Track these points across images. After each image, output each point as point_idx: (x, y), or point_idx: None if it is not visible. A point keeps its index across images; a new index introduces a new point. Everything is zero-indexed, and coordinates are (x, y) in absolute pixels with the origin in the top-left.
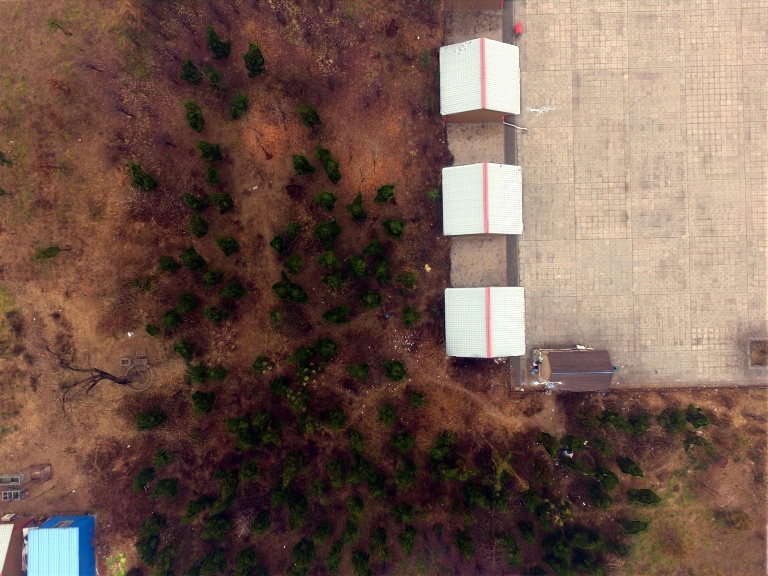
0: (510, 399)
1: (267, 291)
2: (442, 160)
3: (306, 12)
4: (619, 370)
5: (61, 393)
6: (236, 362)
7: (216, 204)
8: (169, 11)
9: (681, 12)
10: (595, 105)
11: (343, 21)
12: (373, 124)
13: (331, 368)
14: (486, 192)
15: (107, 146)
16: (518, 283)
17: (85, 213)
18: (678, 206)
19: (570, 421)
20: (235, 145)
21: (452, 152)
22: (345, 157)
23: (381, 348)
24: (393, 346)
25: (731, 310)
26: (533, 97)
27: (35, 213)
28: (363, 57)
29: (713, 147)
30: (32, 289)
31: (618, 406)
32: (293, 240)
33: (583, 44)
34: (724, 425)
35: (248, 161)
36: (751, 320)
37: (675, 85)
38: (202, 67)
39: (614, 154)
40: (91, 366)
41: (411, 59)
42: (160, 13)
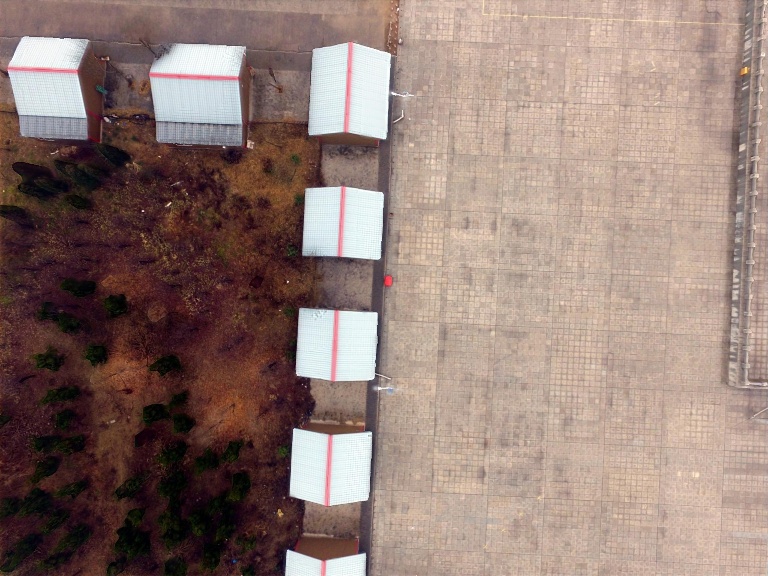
0: None
1: (116, 527)
2: (303, 405)
3: (177, 249)
4: None
5: None
6: None
7: None
8: (40, 240)
9: (552, 273)
10: (460, 359)
11: (213, 261)
12: (236, 365)
13: None
14: (329, 465)
15: None
16: (371, 532)
17: None
18: (536, 466)
19: None
20: None
21: (314, 397)
22: (205, 397)
23: None
24: None
25: (581, 575)
26: (399, 346)
27: None
28: (231, 298)
29: (574, 410)
30: None
31: None
32: (147, 477)
33: (452, 298)
34: None
35: (108, 394)
36: None
37: (541, 345)
38: None
39: (476, 409)
40: None
41: (279, 303)
42: (31, 241)
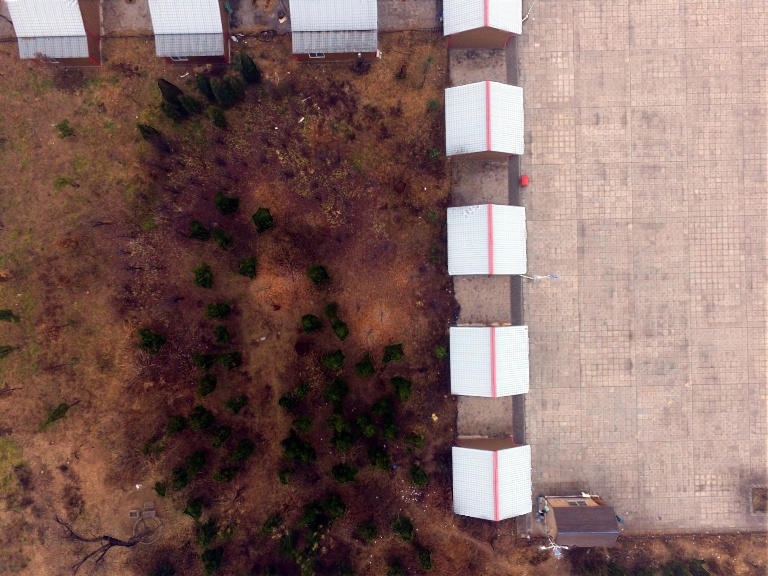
0: (516, 548)
1: (275, 442)
2: (449, 310)
3: (314, 164)
4: (623, 516)
5: (69, 546)
6: (244, 513)
7: (225, 365)
8: None
9: (684, 163)
10: (600, 254)
11: (351, 173)
12: (380, 275)
13: (339, 518)
14: (493, 357)
15: (115, 298)
16: (524, 431)
17: (93, 365)
18: (681, 354)
19: (575, 570)
20: (243, 296)
21: (459, 301)
22: (353, 308)
23: (389, 498)
24: (400, 496)
25: (733, 457)
26: (539, 246)
27: (43, 365)
28: (370, 208)
29: (716, 296)
30: (40, 442)
31: (623, 555)
32: None
33: (588, 194)
34: (727, 574)
35: (256, 312)
36: (753, 467)
37: (678, 235)
38: (211, 229)
39: (618, 303)
40: (101, 535)
41: (418, 210)
42: (168, 165)
